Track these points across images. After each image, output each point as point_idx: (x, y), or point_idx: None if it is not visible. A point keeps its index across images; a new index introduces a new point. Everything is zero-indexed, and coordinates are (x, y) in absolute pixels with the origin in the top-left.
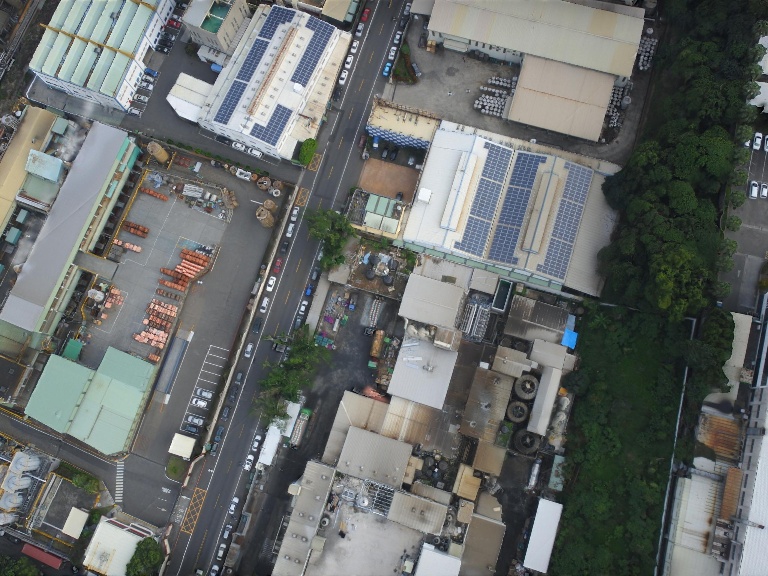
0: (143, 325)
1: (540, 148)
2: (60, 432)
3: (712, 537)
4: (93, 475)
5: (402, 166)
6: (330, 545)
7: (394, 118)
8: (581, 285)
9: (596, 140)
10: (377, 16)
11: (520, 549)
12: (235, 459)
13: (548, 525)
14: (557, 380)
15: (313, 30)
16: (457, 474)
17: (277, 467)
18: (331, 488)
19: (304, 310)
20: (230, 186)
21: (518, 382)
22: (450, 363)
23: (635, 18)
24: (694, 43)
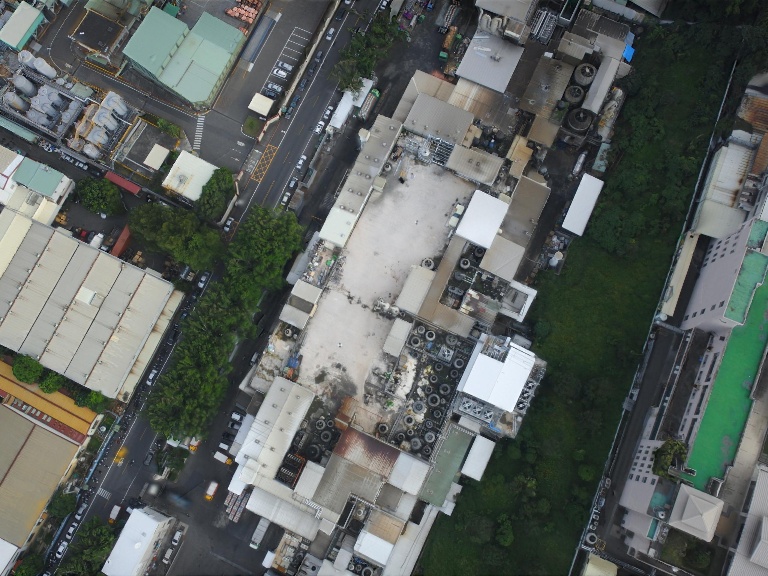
0: (235, 3)
1: None
2: (153, 73)
3: (741, 190)
4: (175, 125)
5: None
6: (389, 189)
7: None
8: (645, 3)
9: None
10: None
11: (558, 224)
12: (307, 124)
13: (588, 196)
14: (614, 69)
15: None
16: (512, 143)
17: (344, 135)
18: (396, 142)
19: (385, 5)
20: None
21: (578, 68)
22: (516, 56)
23: None
24: None
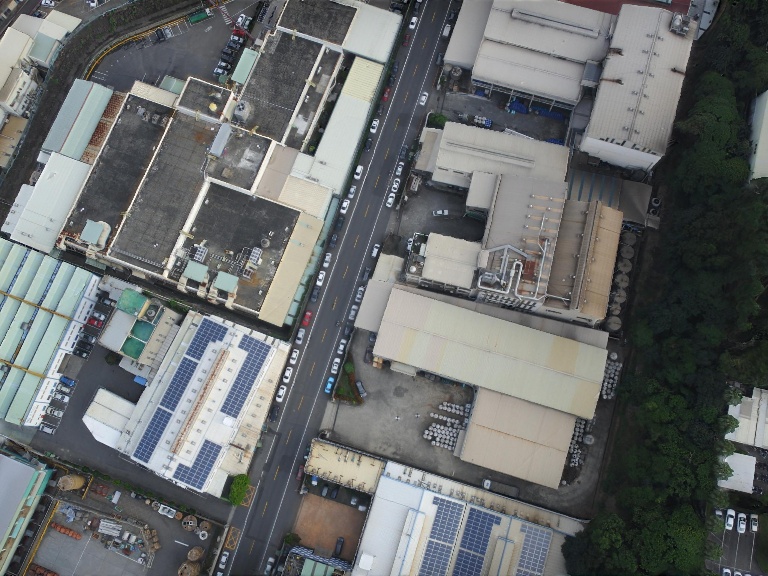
0: None
1: (495, 499)
2: None
3: None
4: None
5: (344, 504)
6: None
7: (335, 457)
8: None
9: (556, 488)
10: (319, 320)
11: None
12: None
13: None
14: None
15: (247, 351)
16: None
17: None
18: None
19: None
20: (152, 522)
21: None
22: None
23: (598, 348)
24: (661, 391)
